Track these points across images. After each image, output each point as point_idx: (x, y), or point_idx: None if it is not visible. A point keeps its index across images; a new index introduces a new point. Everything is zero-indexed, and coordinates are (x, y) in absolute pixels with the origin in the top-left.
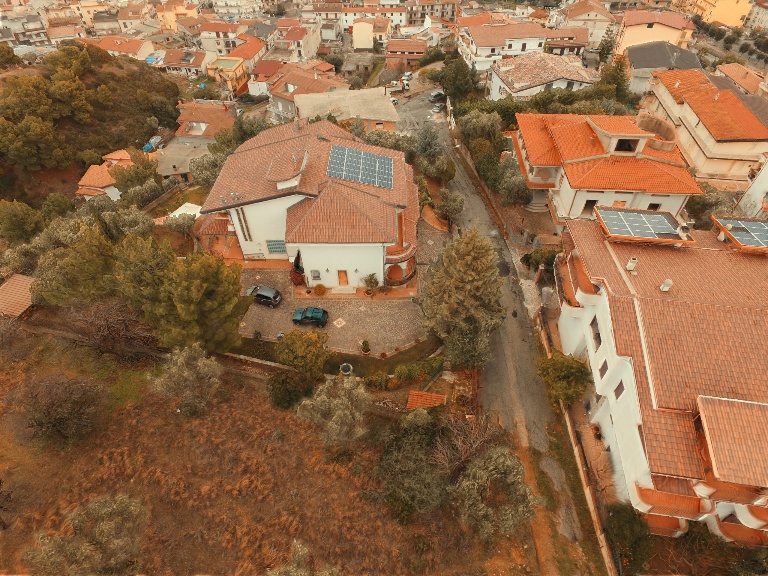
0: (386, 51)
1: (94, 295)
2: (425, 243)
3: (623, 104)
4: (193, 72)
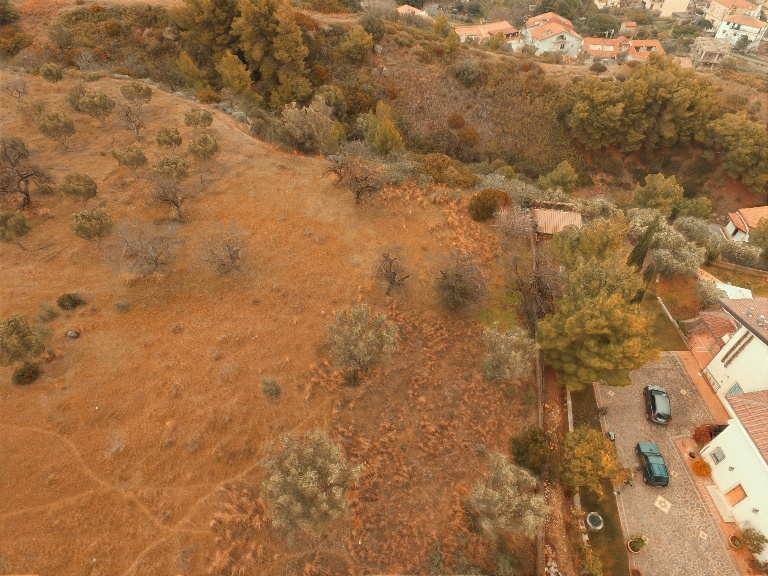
0: None
1: (566, 261)
2: None
3: None
4: None
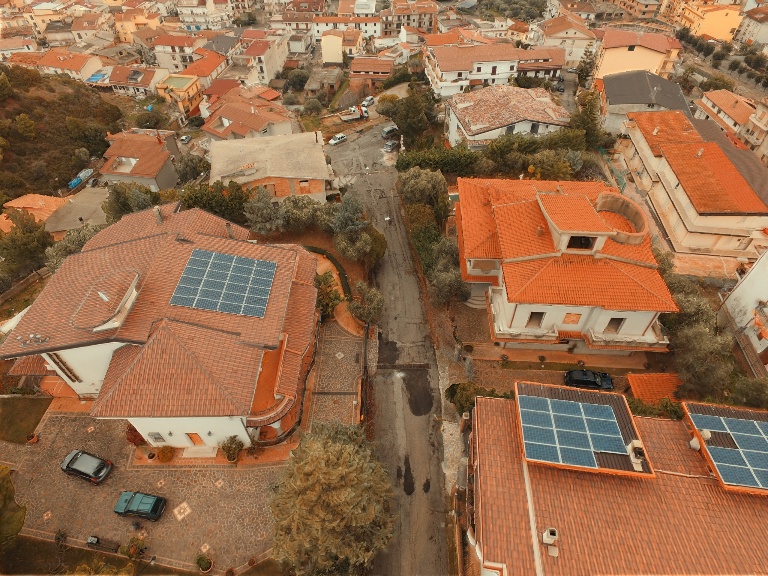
0: (350, 70)
1: None
2: (332, 357)
3: (595, 149)
4: (141, 92)
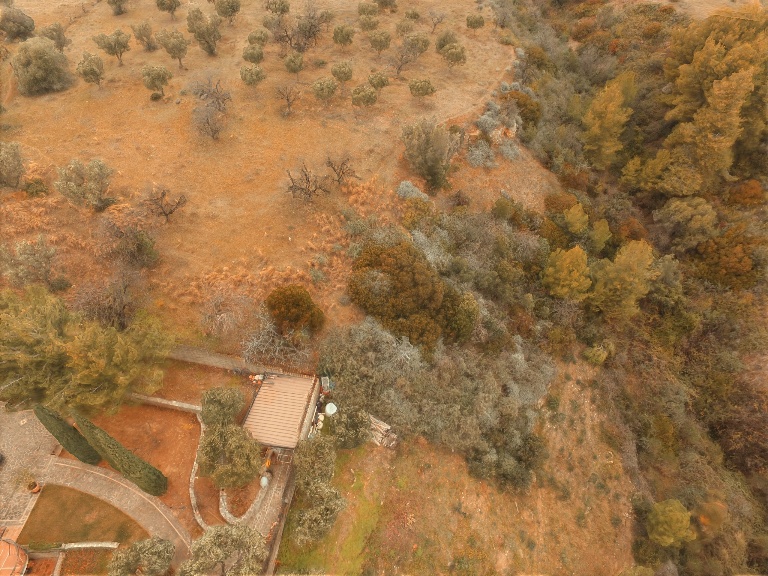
0: None
1: None
2: None
3: None
4: None
